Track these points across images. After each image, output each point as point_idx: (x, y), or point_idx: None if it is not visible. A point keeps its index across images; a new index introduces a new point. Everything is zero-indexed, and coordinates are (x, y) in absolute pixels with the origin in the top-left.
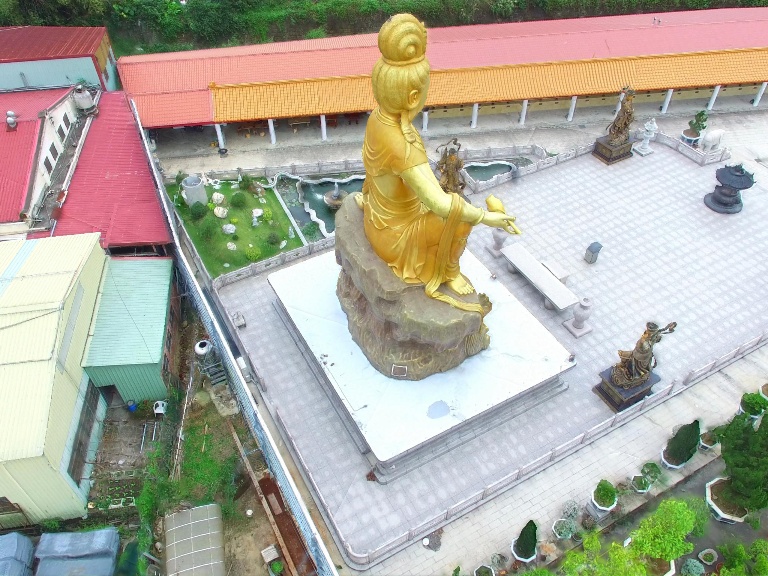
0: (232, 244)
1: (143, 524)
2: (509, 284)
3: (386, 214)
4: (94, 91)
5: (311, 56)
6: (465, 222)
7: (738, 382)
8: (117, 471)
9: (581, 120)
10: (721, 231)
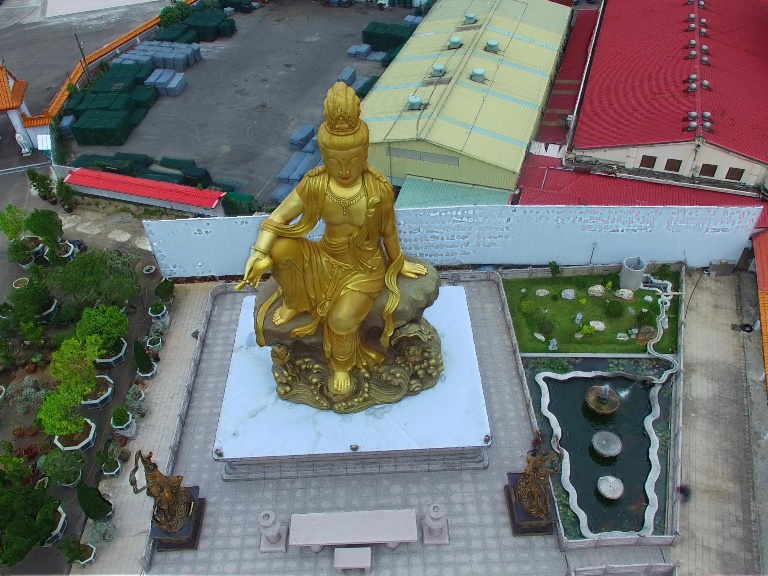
0: (545, 292)
1: None
2: (374, 509)
3: None
4: None
5: None
6: None
7: None
8: None
9: None
10: None
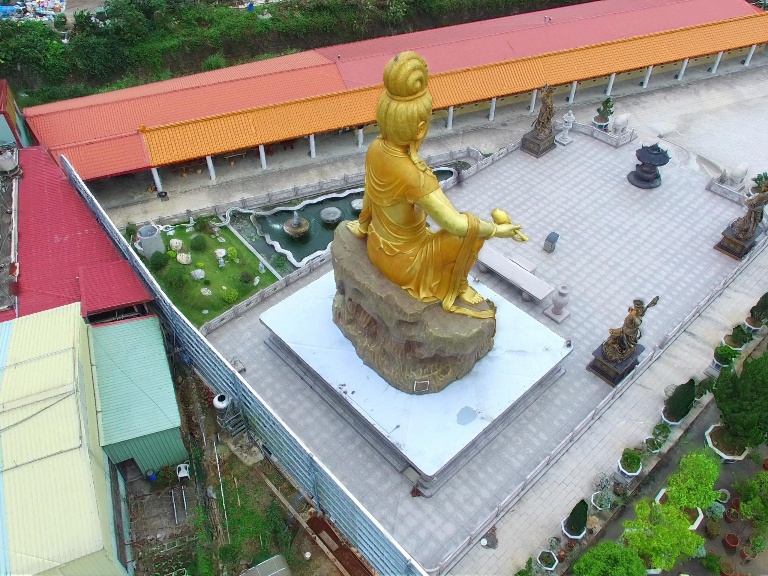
0: (206, 289)
1: None
2: (485, 284)
3: (398, 240)
4: (10, 150)
5: (233, 86)
6: (479, 238)
7: (702, 338)
8: (158, 546)
9: (501, 119)
10: (650, 205)
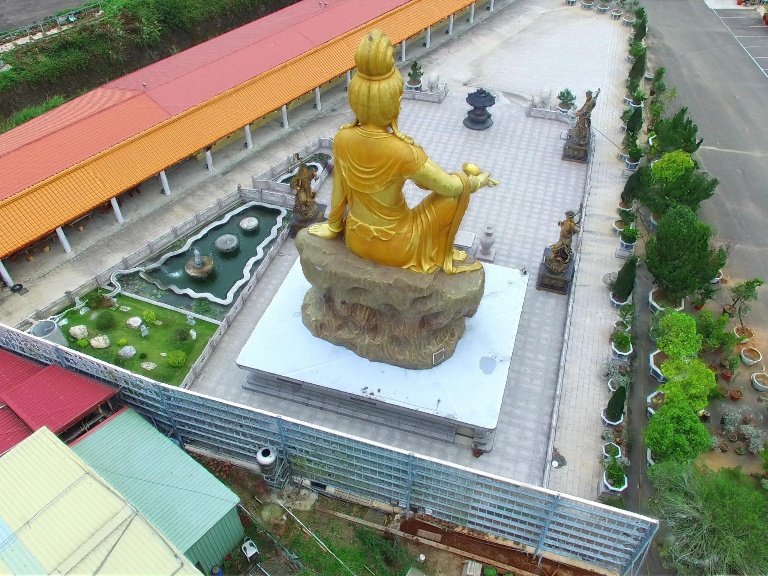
0: (147, 363)
1: None
2: None
3: (392, 223)
4: None
5: (42, 145)
6: None
7: (598, 231)
8: None
9: (328, 105)
10: (496, 142)
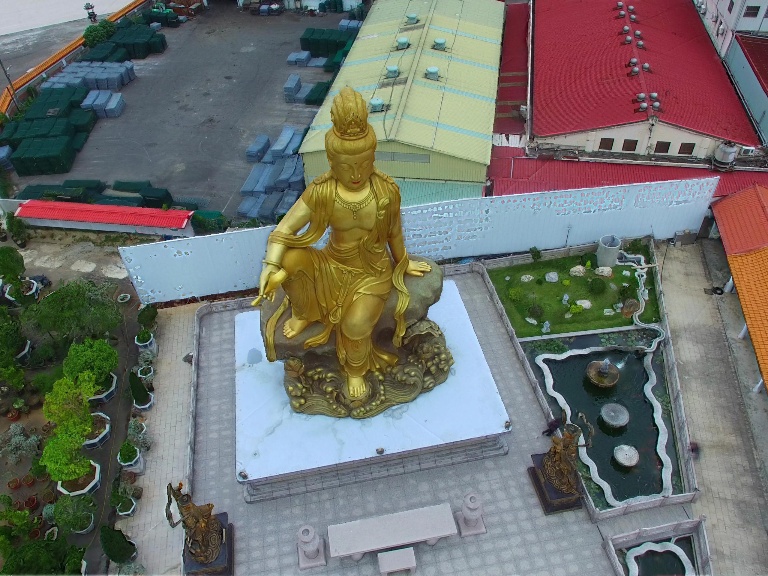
0: (529, 278)
1: None
2: (406, 509)
3: None
4: None
5: None
6: None
7: None
8: None
9: None
10: None
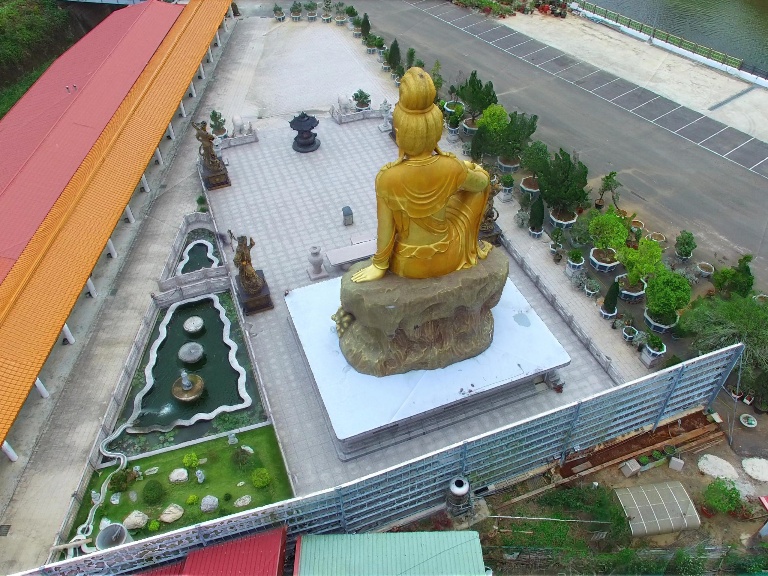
0: (241, 500)
1: (629, 570)
2: None
3: None
4: None
5: None
6: None
7: None
8: None
9: (153, 184)
10: (336, 155)
